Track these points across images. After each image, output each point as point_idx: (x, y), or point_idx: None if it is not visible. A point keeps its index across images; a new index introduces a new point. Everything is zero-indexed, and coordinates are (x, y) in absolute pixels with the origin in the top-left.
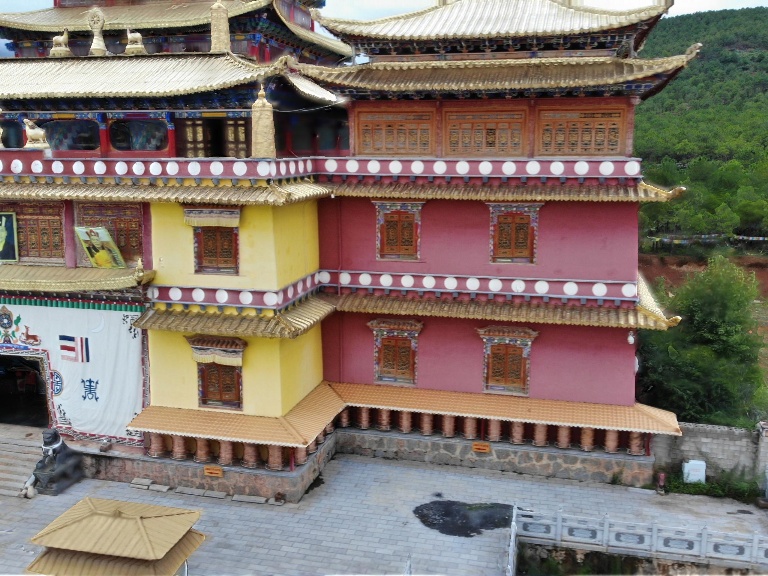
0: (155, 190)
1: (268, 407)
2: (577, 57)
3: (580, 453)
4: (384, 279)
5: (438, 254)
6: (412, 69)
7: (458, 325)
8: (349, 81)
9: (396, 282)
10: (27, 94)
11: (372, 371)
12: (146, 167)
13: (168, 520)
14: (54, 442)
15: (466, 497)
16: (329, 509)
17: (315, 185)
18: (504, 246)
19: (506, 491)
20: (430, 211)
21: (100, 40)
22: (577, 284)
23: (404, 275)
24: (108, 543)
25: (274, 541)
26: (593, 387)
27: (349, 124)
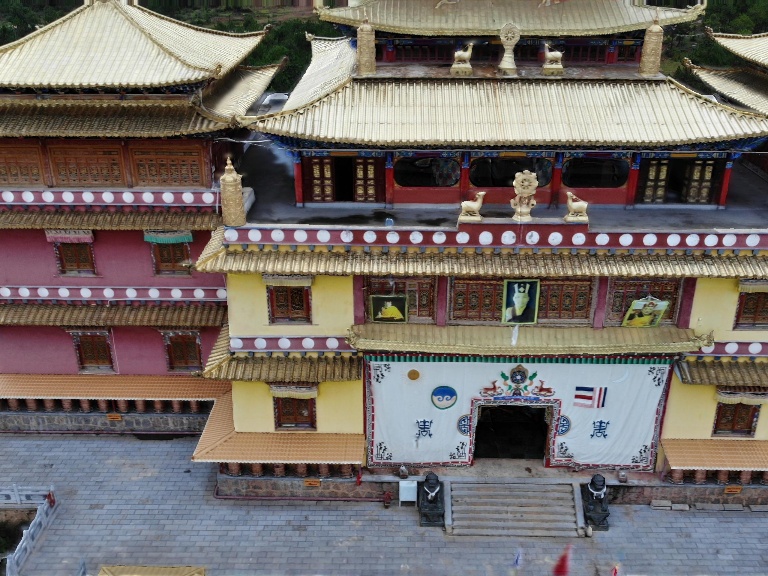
0: (718, 263)
1: None
2: None
3: None
4: None
5: None
6: None
7: None
8: None
9: None
10: (500, 142)
11: None
12: (701, 239)
13: None
14: (603, 486)
15: None
16: None
17: None
18: None
19: None
20: None
21: (513, 58)
22: None
23: None
24: None
25: None
26: None
27: None
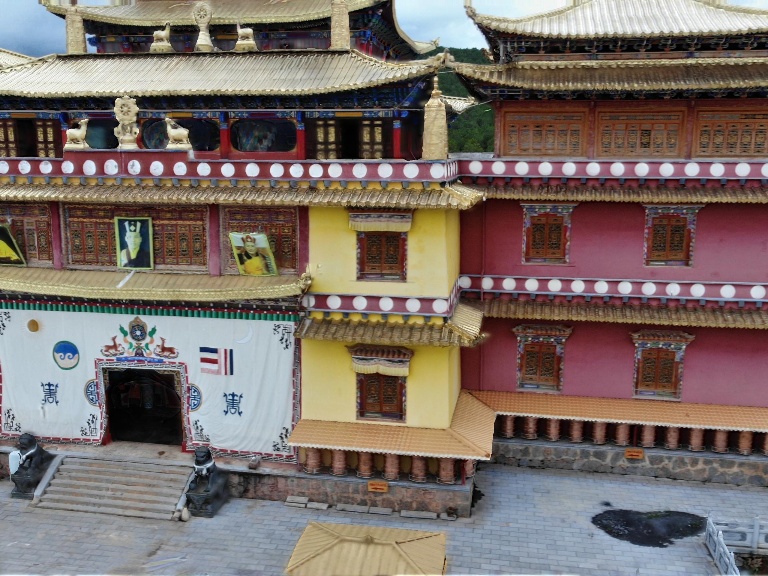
0: (319, 193)
1: (434, 418)
2: (735, 57)
3: (738, 457)
4: (530, 283)
5: (589, 257)
6: (561, 68)
7: (609, 330)
8: (504, 80)
9: (542, 286)
10: (147, 92)
11: (514, 378)
12: (305, 169)
13: (422, 544)
14: (207, 461)
15: (636, 505)
16: (506, 523)
17: (471, 187)
18: (658, 249)
19: (672, 498)
20: (581, 214)
21: (207, 35)
22: (735, 287)
23: (551, 279)
24: (374, 572)
25: (470, 559)
26: (748, 390)
27: (495, 124)
